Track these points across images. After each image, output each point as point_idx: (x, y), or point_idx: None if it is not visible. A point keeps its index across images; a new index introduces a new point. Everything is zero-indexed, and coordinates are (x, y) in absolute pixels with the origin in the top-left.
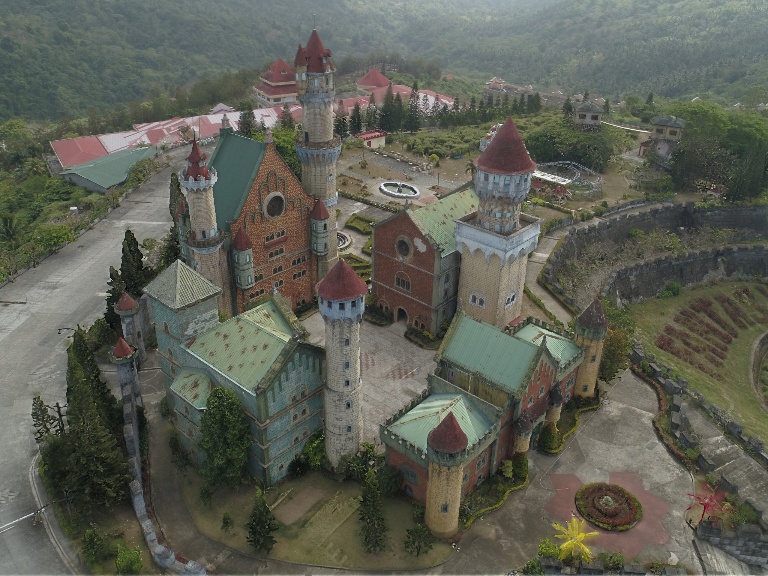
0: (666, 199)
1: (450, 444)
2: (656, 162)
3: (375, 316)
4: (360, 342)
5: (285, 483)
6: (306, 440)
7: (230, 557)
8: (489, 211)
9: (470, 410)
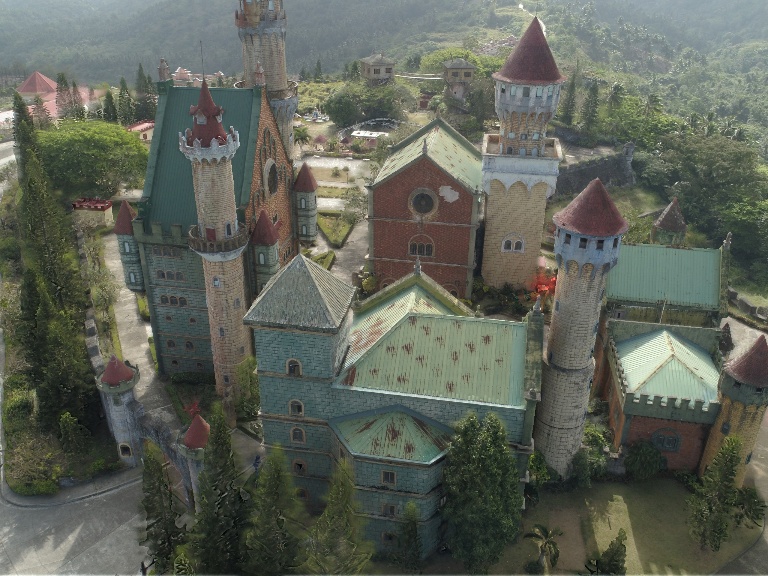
0: (479, 139)
1: None
2: (456, 106)
3: None
4: None
5: (522, 522)
6: None
7: None
8: (525, 134)
9: (683, 344)
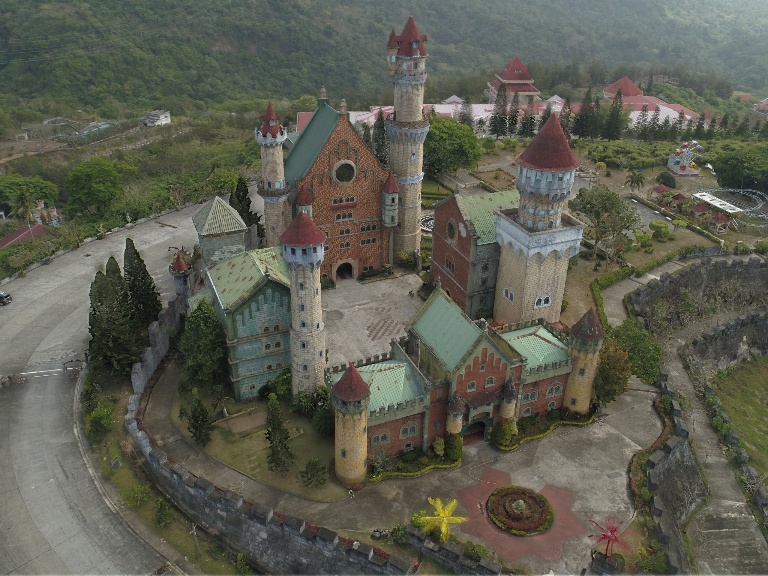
0: None
1: (345, 392)
2: None
3: (428, 293)
4: (400, 312)
5: (253, 402)
6: (281, 371)
7: (178, 441)
8: (524, 206)
9: (408, 378)
